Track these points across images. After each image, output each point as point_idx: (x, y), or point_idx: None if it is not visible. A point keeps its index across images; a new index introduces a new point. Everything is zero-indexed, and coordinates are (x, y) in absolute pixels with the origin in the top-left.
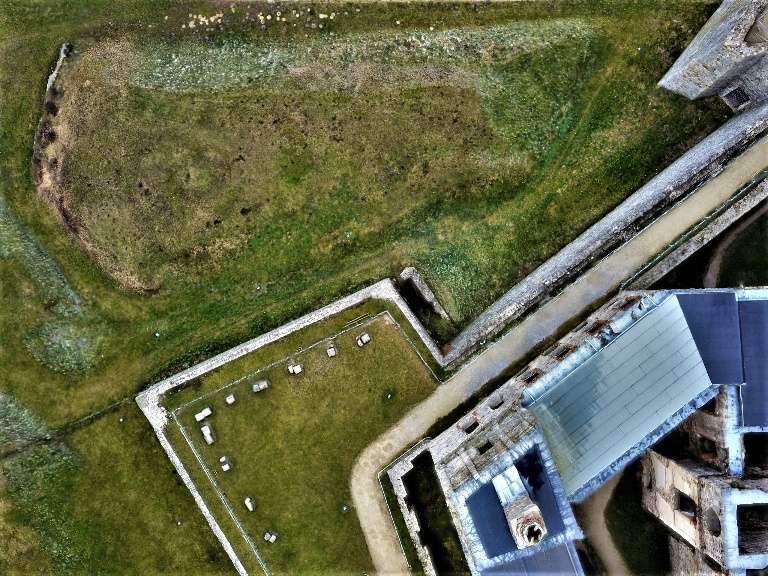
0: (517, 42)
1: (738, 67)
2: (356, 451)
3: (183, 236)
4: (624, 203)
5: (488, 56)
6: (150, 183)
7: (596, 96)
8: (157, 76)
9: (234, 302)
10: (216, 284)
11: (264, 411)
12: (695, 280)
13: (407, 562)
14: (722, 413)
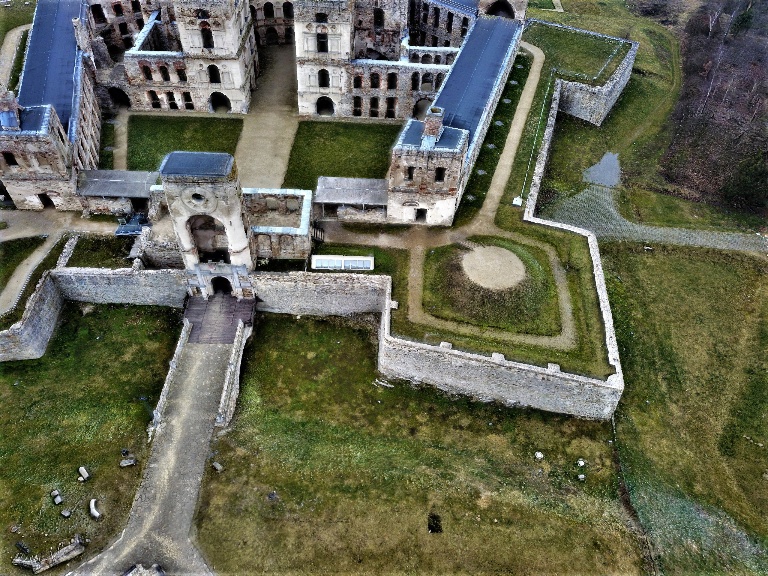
0: None
1: None
2: (18, 25)
3: None
4: None
5: None
6: None
7: None
8: None
9: None
10: None
11: None
12: None
13: None
14: None
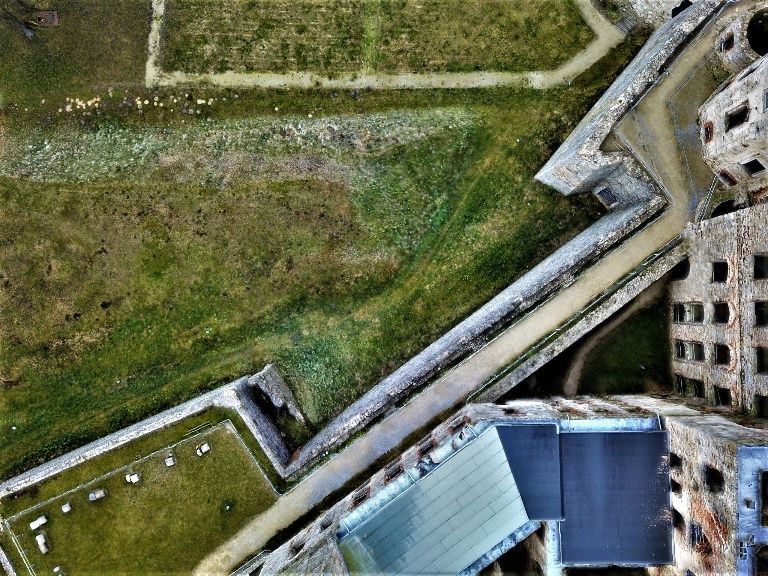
0: (392, 133)
1: (598, 173)
2: (193, 563)
3: (42, 329)
4: (490, 303)
5: (362, 147)
6: (11, 274)
7: (472, 188)
8: (25, 164)
9: (94, 395)
10: (77, 376)
11: (100, 520)
12: (555, 386)
13: None
14: (546, 546)
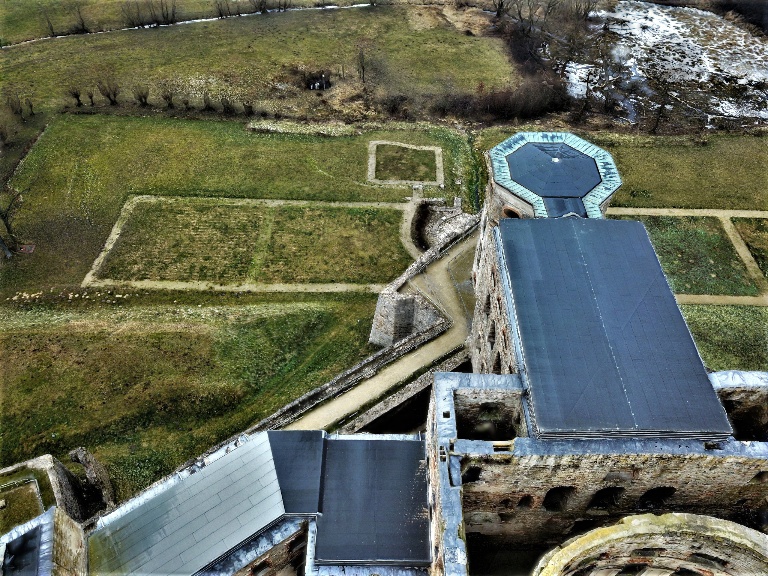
0: (259, 312)
1: (401, 313)
2: None
3: None
4: None
5: (233, 319)
6: None
7: (319, 350)
8: None
9: None
10: None
11: None
12: None
13: None
14: None
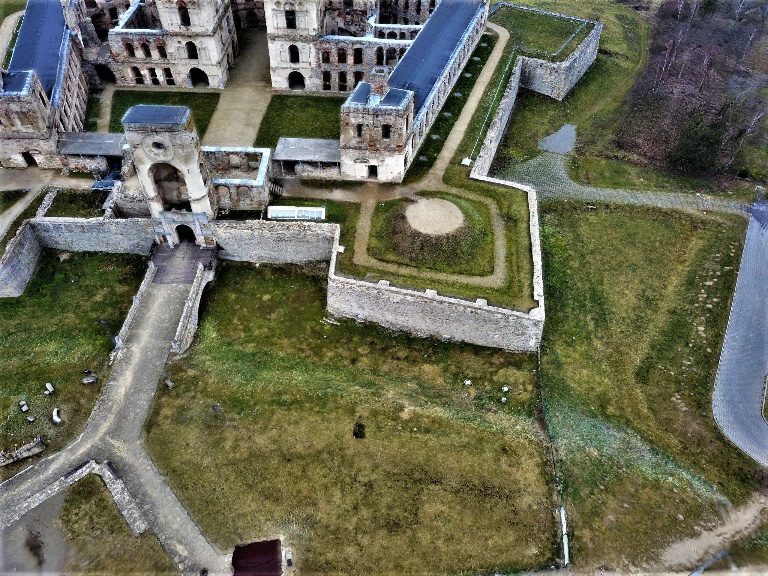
0: None
1: None
2: None
3: None
4: None
5: None
6: None
7: None
8: None
9: None
10: None
11: None
12: None
13: (14, 31)
14: None
